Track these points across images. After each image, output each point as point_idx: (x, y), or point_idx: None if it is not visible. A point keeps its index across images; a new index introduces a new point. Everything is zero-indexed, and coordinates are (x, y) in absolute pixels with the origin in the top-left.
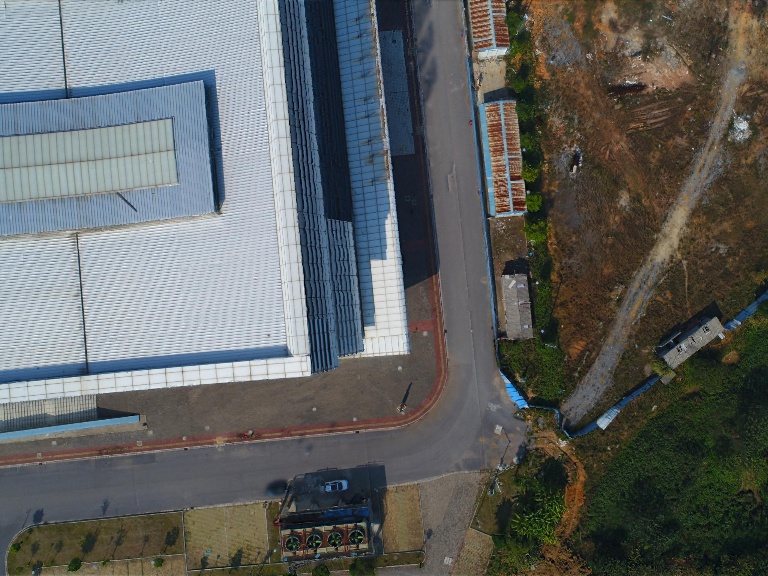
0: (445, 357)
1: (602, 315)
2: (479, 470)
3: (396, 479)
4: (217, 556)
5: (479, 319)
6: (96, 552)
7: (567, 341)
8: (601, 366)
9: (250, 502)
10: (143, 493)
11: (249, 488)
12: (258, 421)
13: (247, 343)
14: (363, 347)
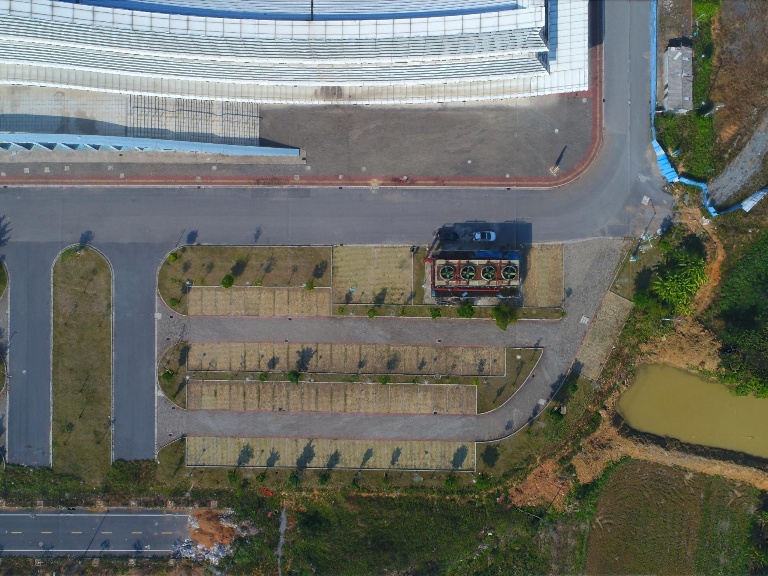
0: (601, 125)
1: (757, 102)
2: (623, 237)
3: (542, 237)
4: (361, 293)
5: (638, 92)
6: (245, 277)
7: (720, 124)
8: (751, 150)
9: (398, 245)
10: (296, 225)
11: (398, 231)
12: (414, 168)
13: (475, 3)
14: (549, 70)
